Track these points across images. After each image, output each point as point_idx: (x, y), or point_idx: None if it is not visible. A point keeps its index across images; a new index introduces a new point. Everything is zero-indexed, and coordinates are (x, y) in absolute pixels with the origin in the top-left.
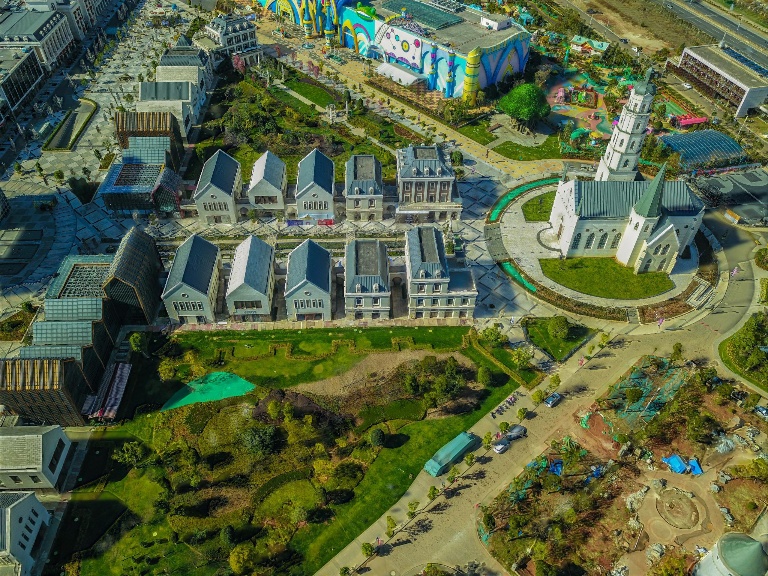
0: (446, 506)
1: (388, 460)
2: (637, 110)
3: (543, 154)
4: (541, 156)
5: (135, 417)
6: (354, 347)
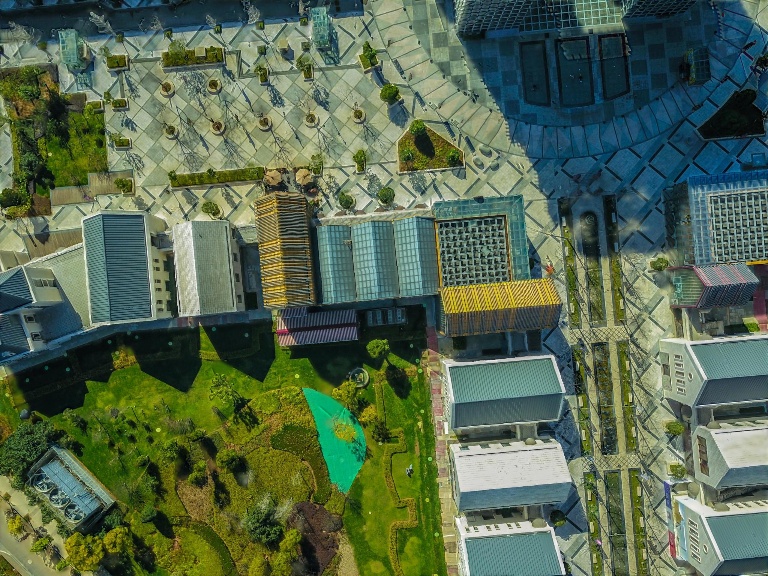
0: None
1: None
2: None
3: None
4: None
5: (294, 361)
6: None
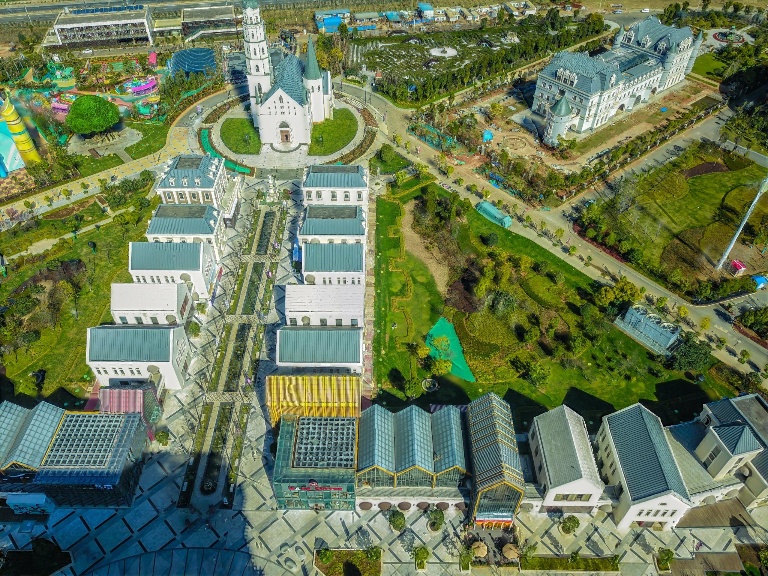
0: (531, 221)
1: (503, 243)
2: (259, 21)
3: (159, 133)
4: (162, 135)
5: None
6: (398, 258)
